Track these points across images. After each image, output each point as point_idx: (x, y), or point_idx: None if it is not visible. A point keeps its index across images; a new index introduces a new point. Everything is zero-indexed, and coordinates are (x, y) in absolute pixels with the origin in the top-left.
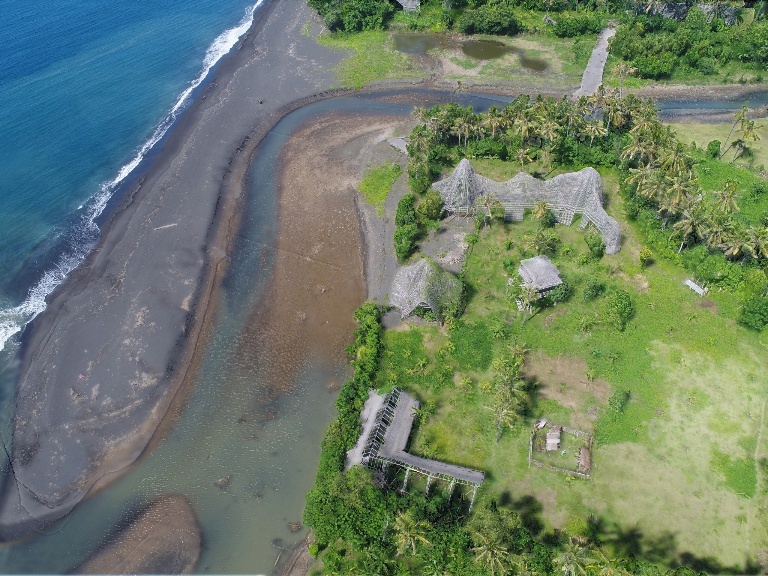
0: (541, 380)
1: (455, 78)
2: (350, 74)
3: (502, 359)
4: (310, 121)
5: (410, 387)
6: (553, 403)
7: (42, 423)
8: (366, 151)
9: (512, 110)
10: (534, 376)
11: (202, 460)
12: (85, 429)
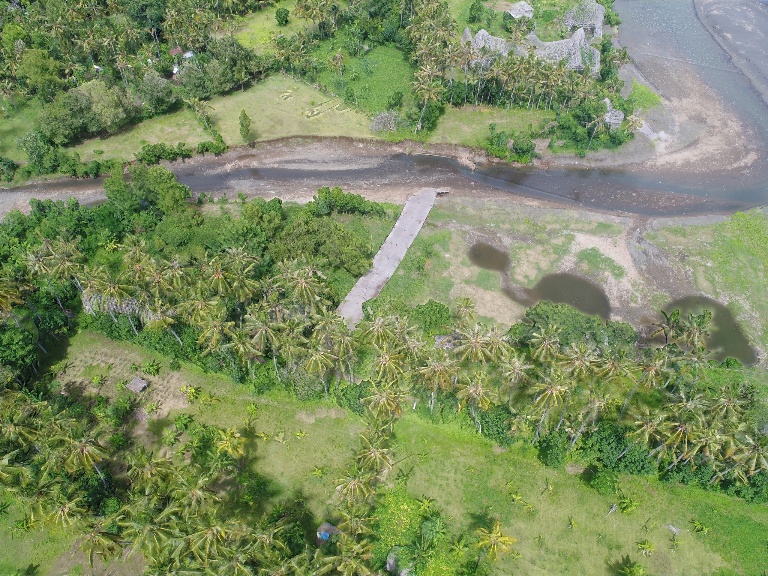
0: None
1: (606, 224)
2: (766, 234)
3: (538, 5)
4: (762, 169)
5: None
6: (512, 2)
7: (751, 4)
8: (673, 128)
9: None
10: None
11: (665, 0)
12: (728, 3)
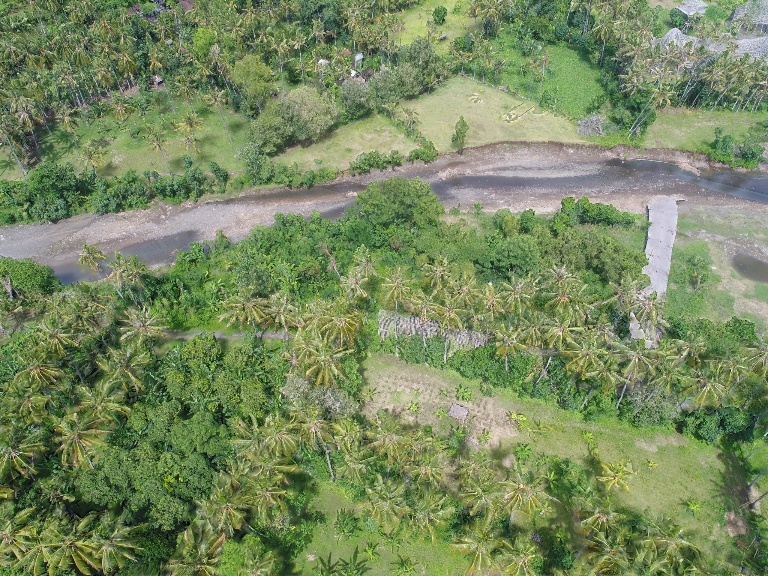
0: (672, 3)
1: None
2: None
3: None
4: None
5: (738, 1)
6: None
7: None
8: None
9: (763, 71)
10: (676, 4)
11: None
12: None
